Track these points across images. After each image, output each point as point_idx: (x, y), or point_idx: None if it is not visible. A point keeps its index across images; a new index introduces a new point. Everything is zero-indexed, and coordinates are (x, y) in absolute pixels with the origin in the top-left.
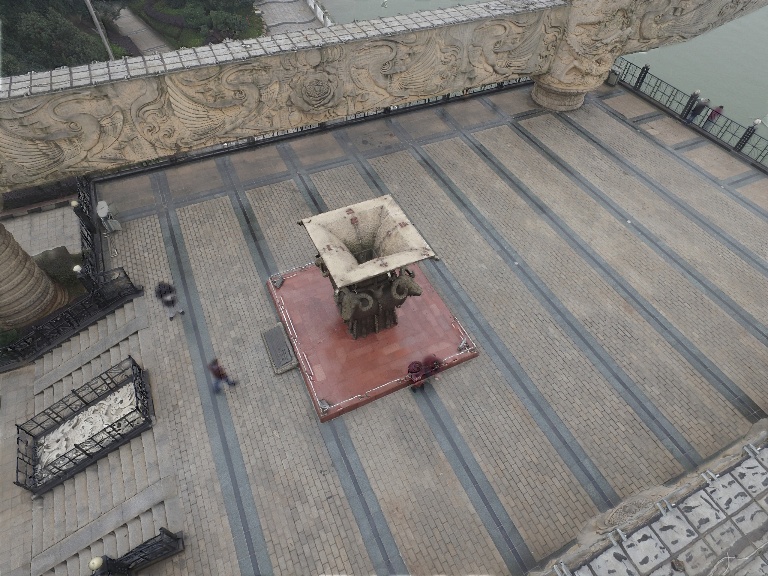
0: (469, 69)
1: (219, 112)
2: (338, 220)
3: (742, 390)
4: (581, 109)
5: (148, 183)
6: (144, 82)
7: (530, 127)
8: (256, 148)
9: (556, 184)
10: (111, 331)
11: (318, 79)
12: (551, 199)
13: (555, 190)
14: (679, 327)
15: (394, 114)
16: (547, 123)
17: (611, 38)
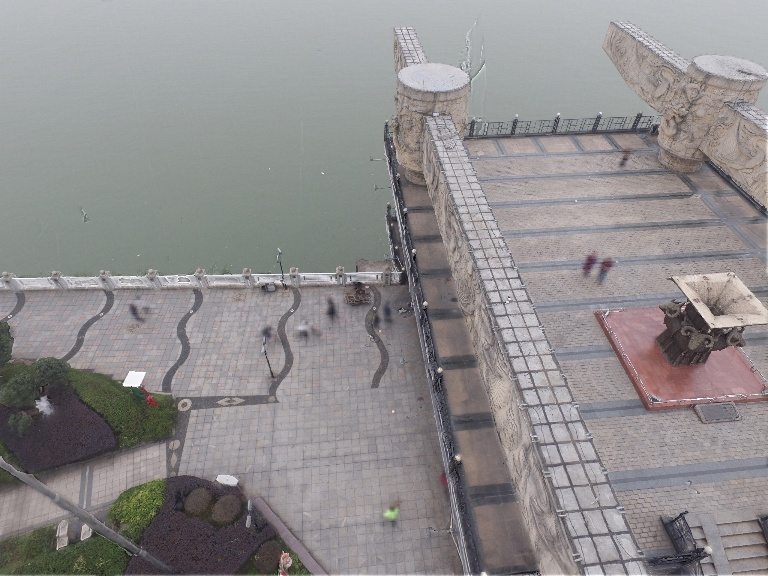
0: None
1: None
2: (707, 309)
3: (705, 219)
4: None
5: (489, 508)
6: None
7: None
8: (443, 388)
9: (534, 215)
10: (707, 559)
11: None
12: (550, 223)
13: (541, 218)
14: (665, 220)
15: None
16: None
17: None
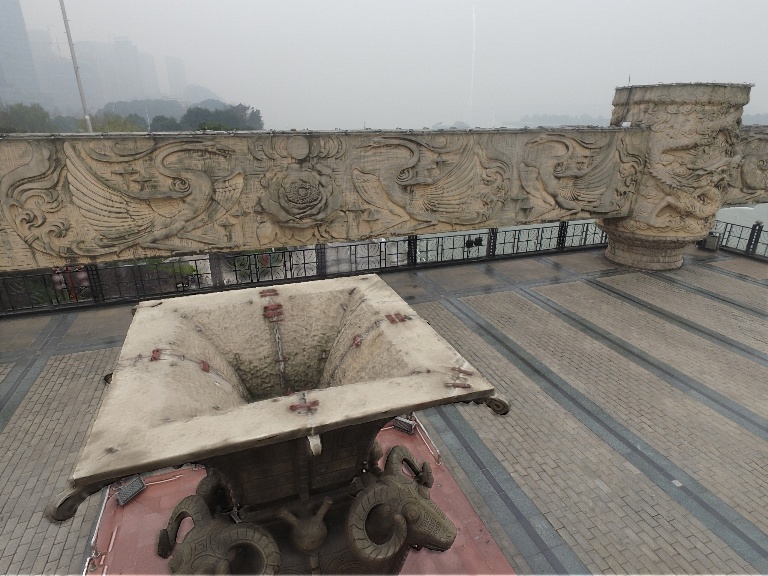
0: (522, 196)
1: (146, 208)
2: (230, 306)
3: None
4: (682, 269)
5: (43, 324)
6: (30, 147)
7: (616, 284)
8: None
9: (692, 348)
10: None
11: (304, 180)
12: (694, 368)
13: (695, 356)
14: None
15: (421, 268)
16: (639, 281)
17: (716, 165)
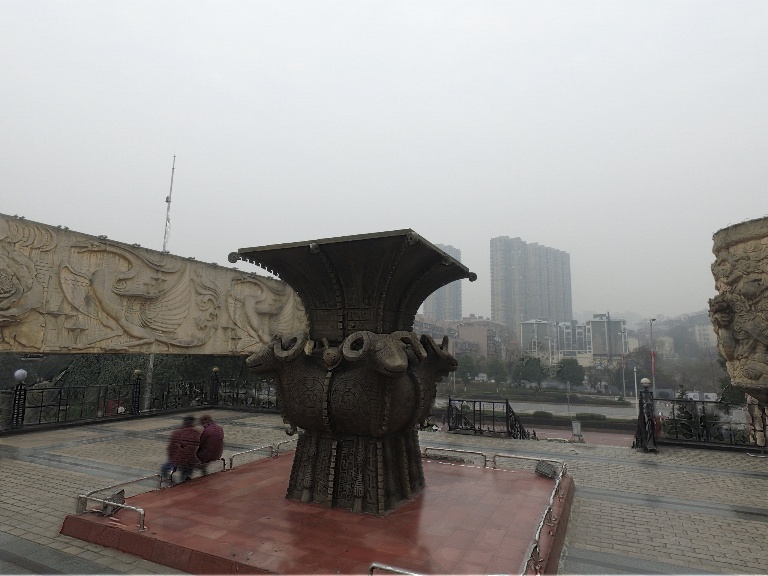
0: None
1: None
2: None
3: None
4: None
5: None
6: None
7: None
8: None
9: None
10: None
11: None
12: None
13: None
14: None
15: None
16: None
17: None
